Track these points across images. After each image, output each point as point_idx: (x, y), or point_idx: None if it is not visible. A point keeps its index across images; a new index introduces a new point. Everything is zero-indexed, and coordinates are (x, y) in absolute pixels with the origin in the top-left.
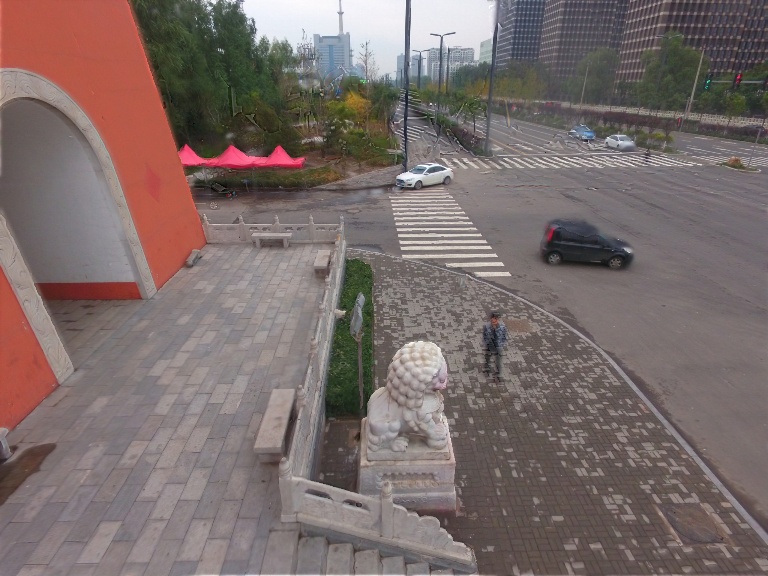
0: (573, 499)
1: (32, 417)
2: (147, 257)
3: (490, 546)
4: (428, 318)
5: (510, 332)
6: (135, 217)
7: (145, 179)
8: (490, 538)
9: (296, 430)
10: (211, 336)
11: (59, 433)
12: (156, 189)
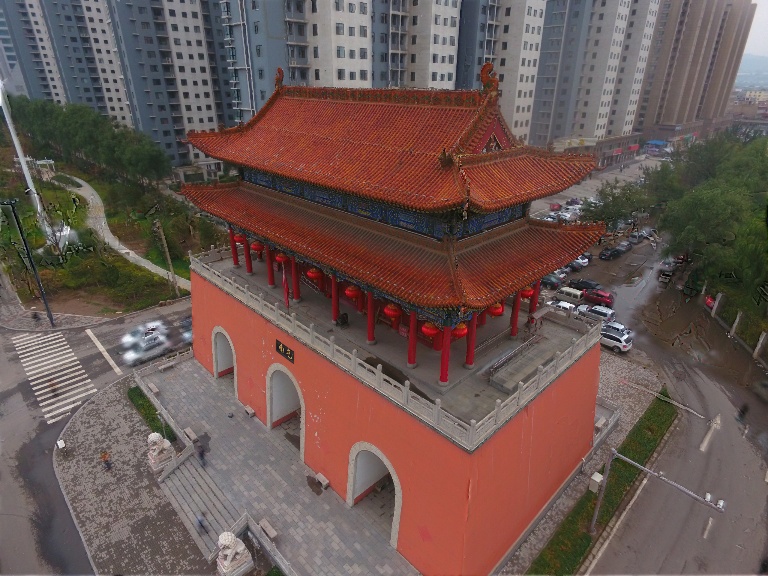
0: None
1: (336, 494)
2: (400, 539)
3: (205, 568)
4: None
5: None
6: (402, 524)
7: (421, 527)
8: (206, 570)
9: (254, 522)
10: (335, 547)
11: (322, 497)
12: (426, 538)
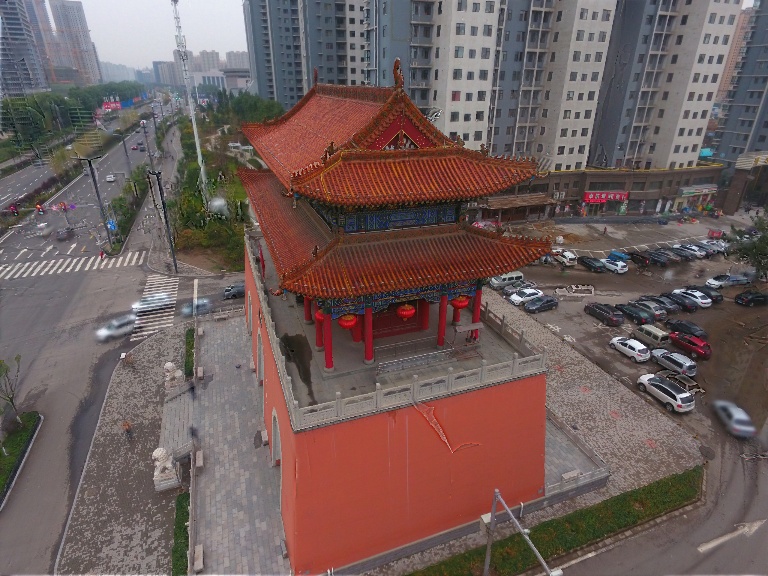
0: (123, 489)
1: (269, 452)
2: None
3: None
4: (140, 573)
5: (97, 571)
6: None
7: None
8: None
9: None
10: (238, 492)
11: None
12: None
